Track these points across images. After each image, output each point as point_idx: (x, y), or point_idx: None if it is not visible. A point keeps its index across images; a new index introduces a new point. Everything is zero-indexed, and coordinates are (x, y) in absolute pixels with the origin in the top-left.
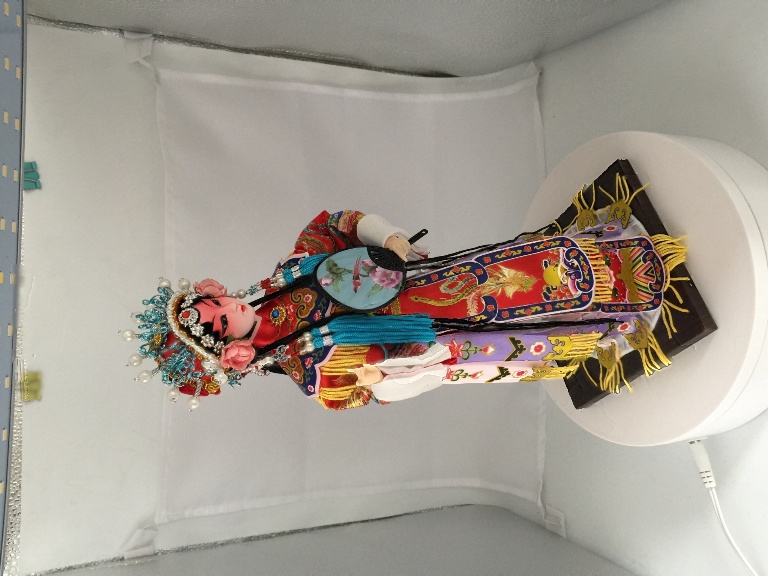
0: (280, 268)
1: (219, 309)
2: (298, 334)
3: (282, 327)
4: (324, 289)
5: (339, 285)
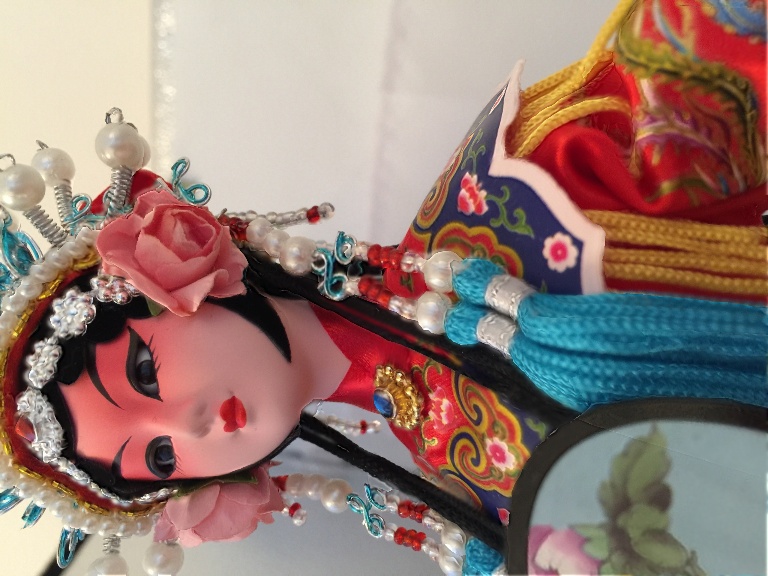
0: (479, 185)
1: (142, 421)
2: (431, 507)
3: (403, 428)
4: None
5: None
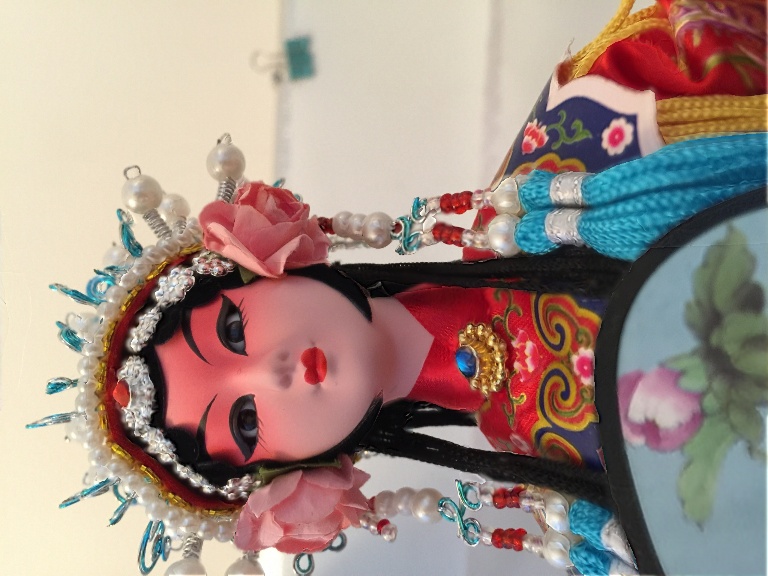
0: (539, 123)
1: (228, 376)
2: (527, 480)
3: (491, 401)
4: (626, 460)
5: (720, 481)
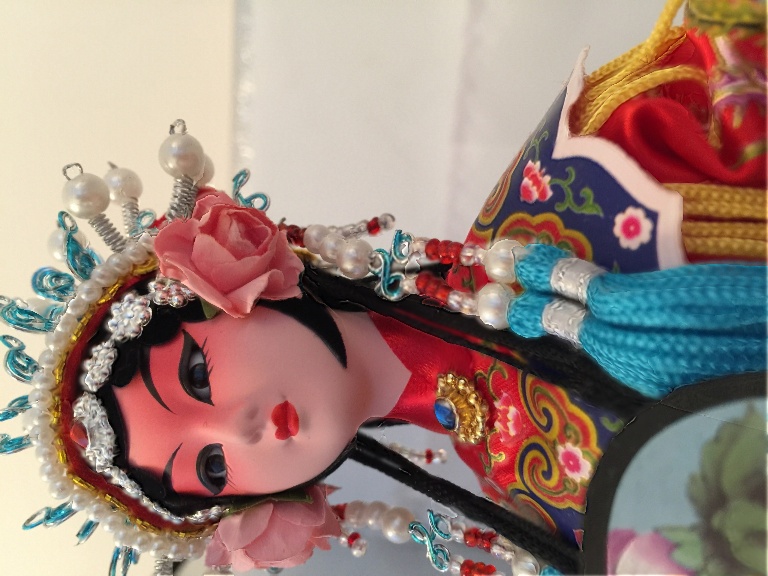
0: (542, 171)
1: (193, 427)
2: (500, 533)
3: (468, 445)
4: None
5: None
